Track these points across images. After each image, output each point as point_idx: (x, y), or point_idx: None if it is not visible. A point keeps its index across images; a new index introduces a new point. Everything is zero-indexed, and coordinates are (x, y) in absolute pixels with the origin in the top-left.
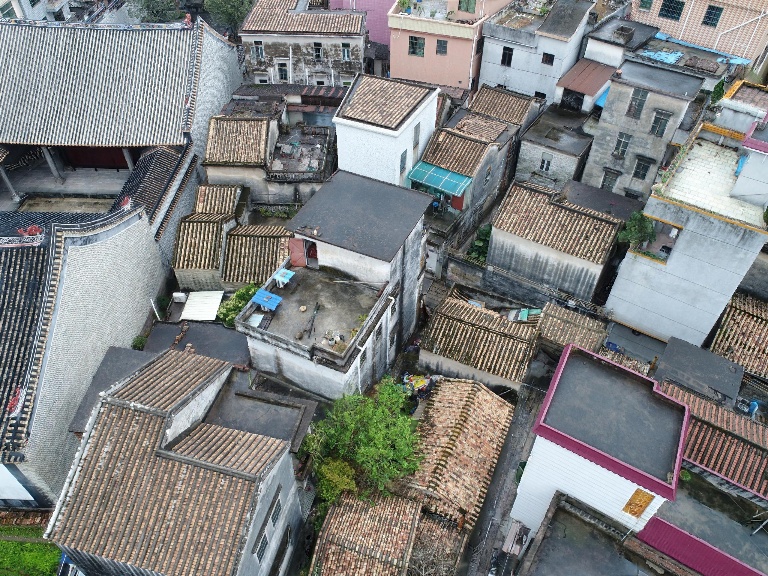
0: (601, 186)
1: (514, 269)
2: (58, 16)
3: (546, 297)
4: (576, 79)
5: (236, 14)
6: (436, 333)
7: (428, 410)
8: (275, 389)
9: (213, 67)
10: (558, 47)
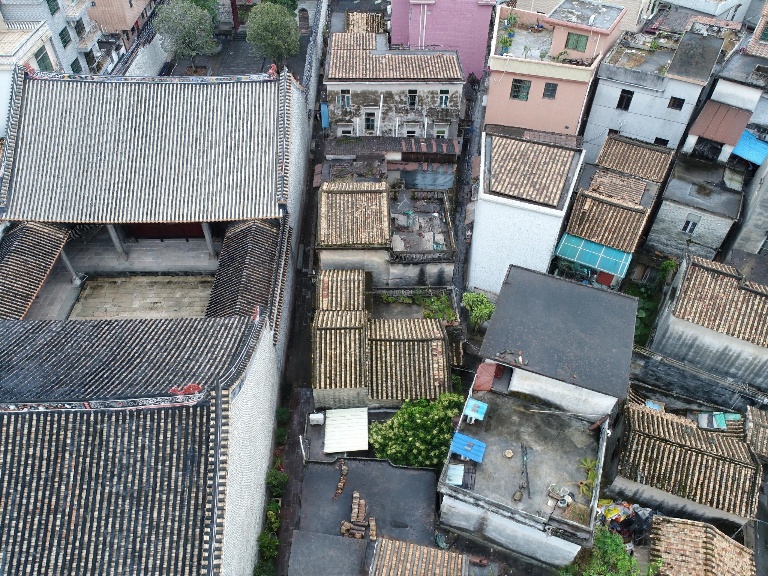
0: (758, 251)
1: (690, 360)
2: (88, 55)
3: (727, 390)
4: (710, 126)
5: (283, 46)
6: (636, 456)
7: (656, 564)
8: (472, 550)
9: (295, 120)
10: (691, 91)
